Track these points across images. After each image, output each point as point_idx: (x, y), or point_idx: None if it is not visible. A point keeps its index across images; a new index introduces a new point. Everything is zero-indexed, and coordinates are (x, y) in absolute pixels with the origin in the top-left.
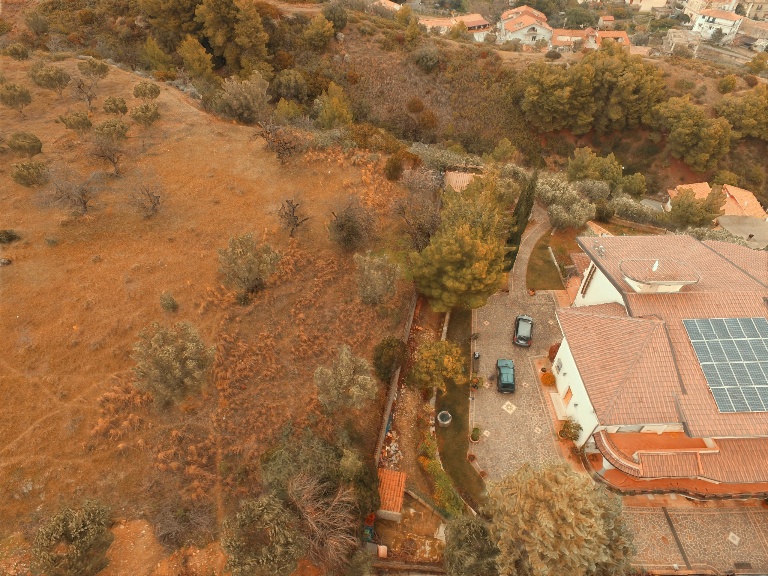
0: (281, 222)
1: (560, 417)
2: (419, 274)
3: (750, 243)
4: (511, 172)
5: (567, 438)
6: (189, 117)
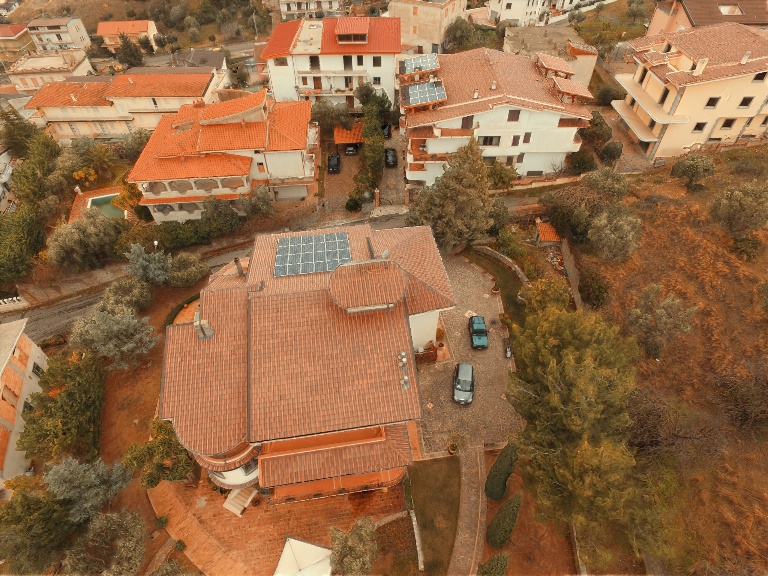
0: None
1: None
2: None
3: None
4: None
5: None
6: None
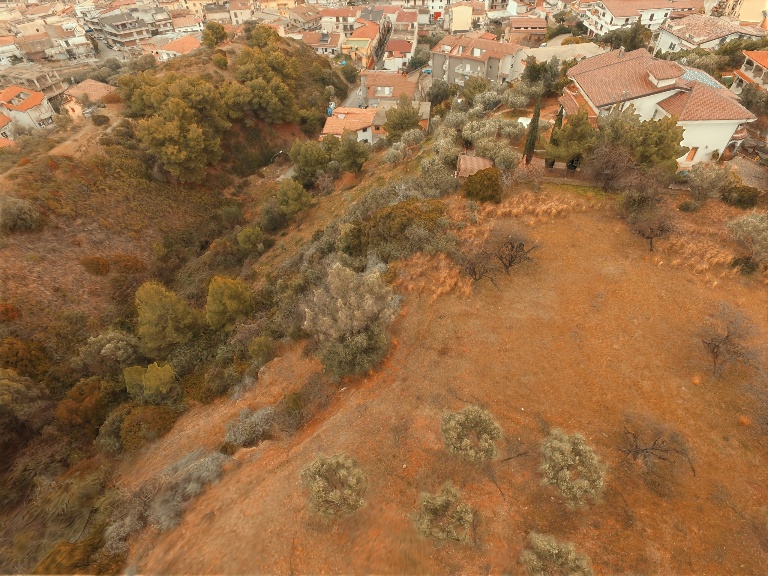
0: (635, 258)
1: None
2: None
3: None
4: None
5: None
6: (379, 416)
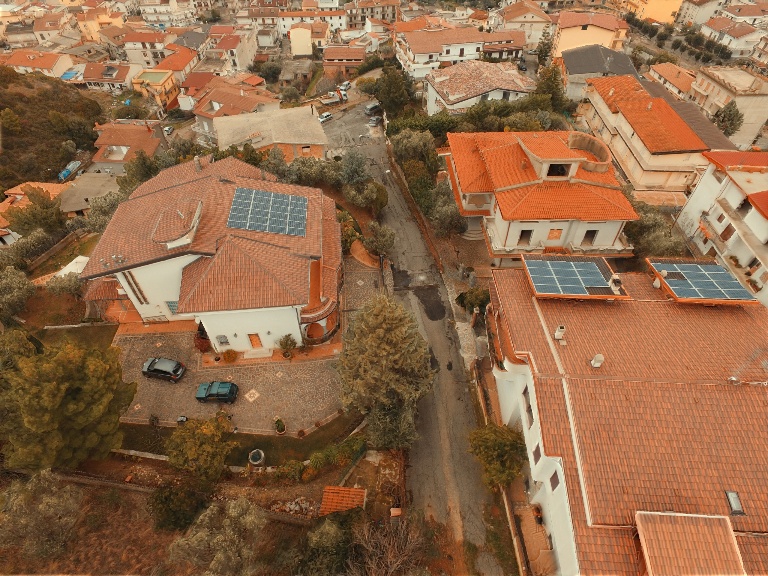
0: None
1: (269, 355)
2: (54, 456)
3: None
4: None
5: (290, 353)
6: None
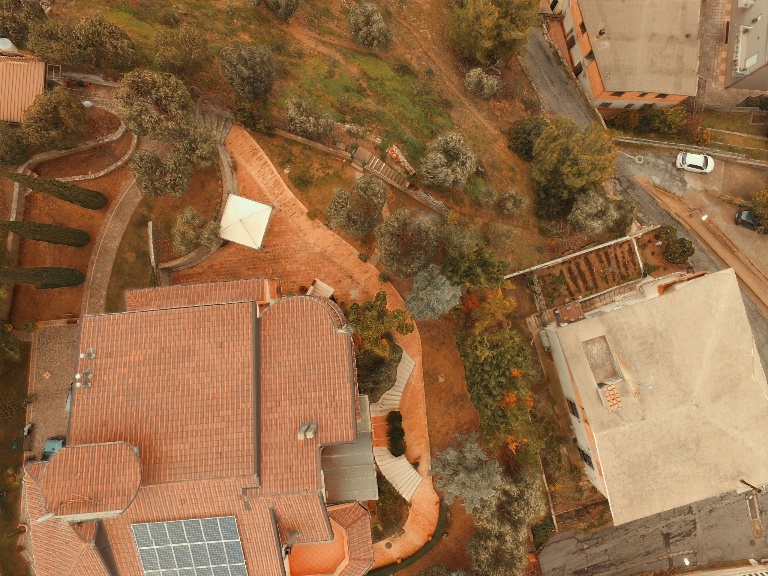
0: None
1: None
2: None
3: (598, 43)
4: (91, 39)
5: None
6: None
